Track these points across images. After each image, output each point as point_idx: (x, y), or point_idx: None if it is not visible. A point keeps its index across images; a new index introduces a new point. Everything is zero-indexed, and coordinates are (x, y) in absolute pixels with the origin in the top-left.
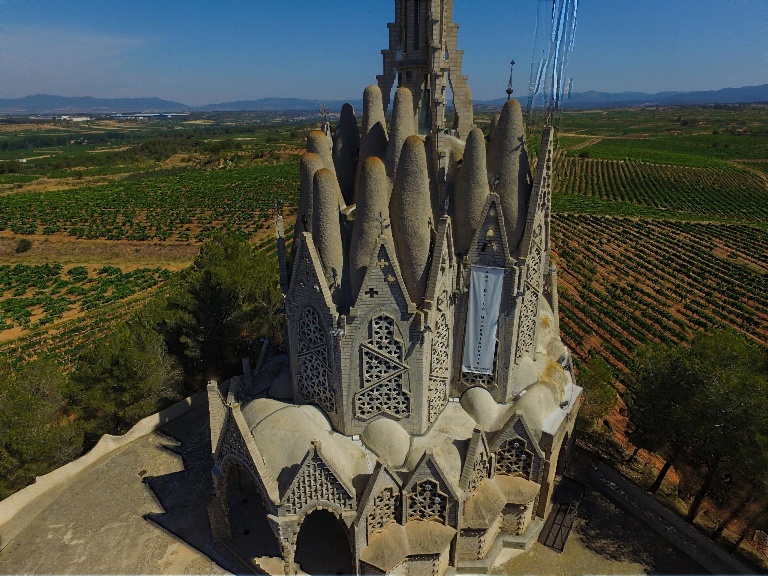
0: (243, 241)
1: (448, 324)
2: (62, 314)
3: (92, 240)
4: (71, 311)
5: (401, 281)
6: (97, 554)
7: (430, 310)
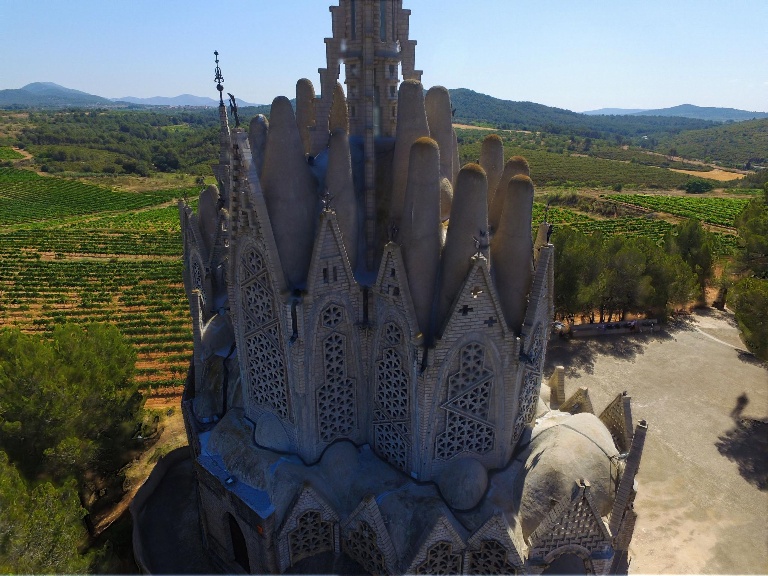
0: None
1: None
2: None
3: None
4: None
5: None
6: None
7: None
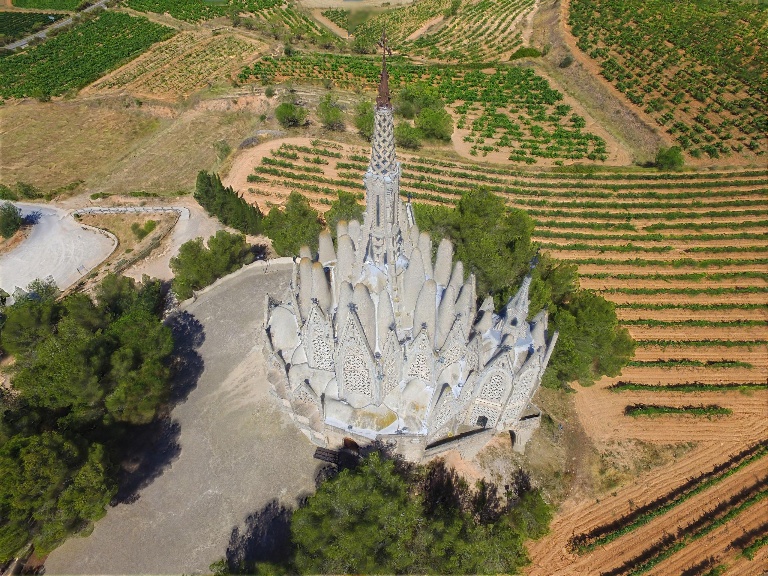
0: (678, 162)
1: (327, 343)
2: (503, 147)
3: (606, 81)
4: (510, 148)
5: (295, 309)
6: (277, 296)
7: (304, 329)
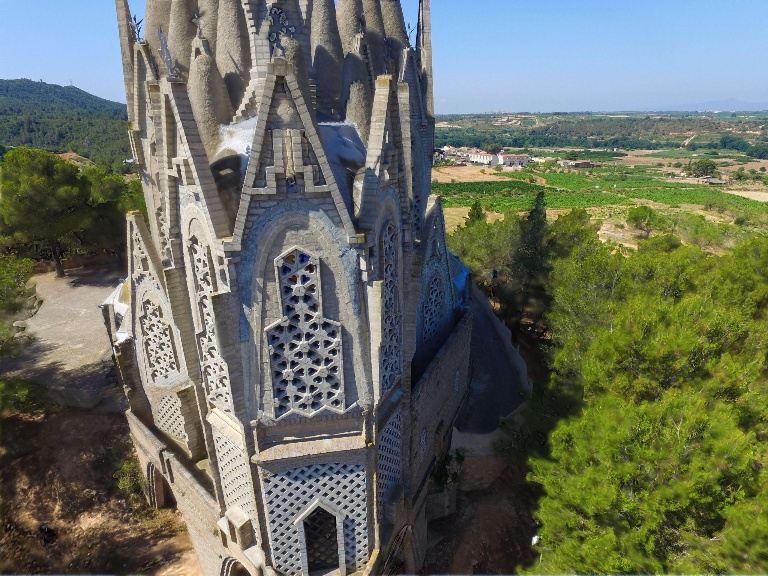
0: None
1: None
2: None
3: None
4: None
5: None
6: None
7: None
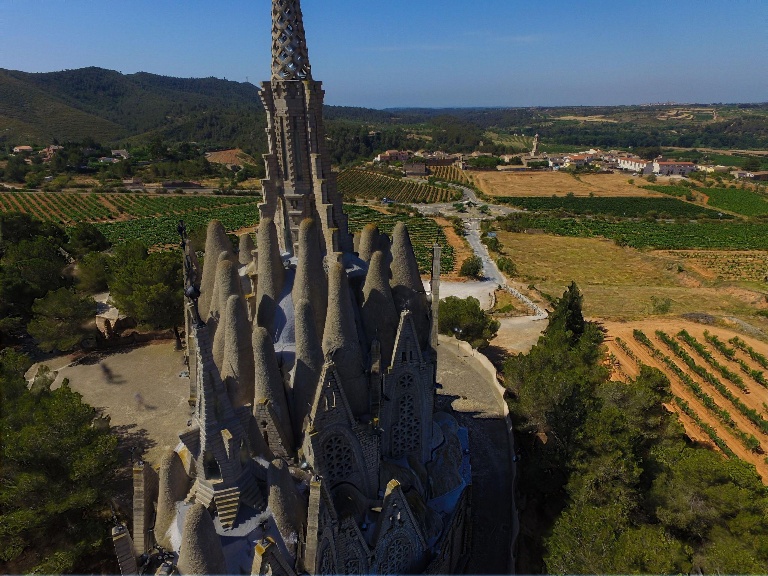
0: None
1: None
2: None
3: None
4: None
5: None
6: None
7: None
